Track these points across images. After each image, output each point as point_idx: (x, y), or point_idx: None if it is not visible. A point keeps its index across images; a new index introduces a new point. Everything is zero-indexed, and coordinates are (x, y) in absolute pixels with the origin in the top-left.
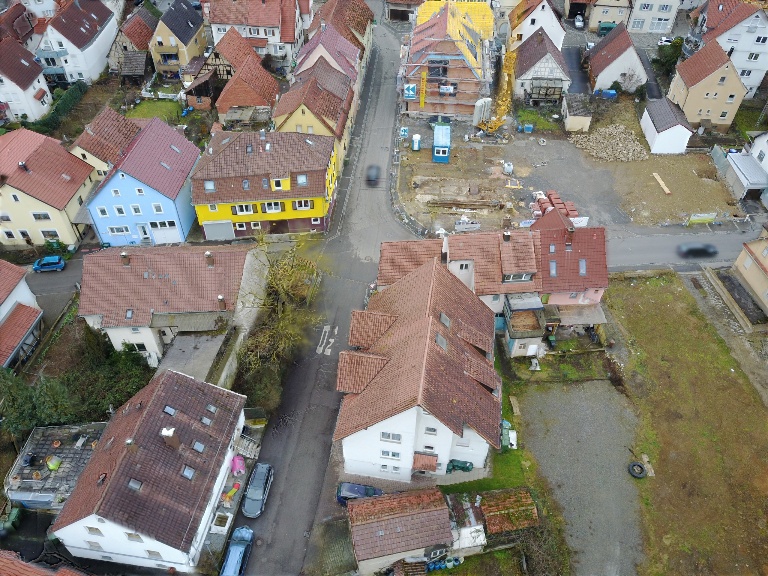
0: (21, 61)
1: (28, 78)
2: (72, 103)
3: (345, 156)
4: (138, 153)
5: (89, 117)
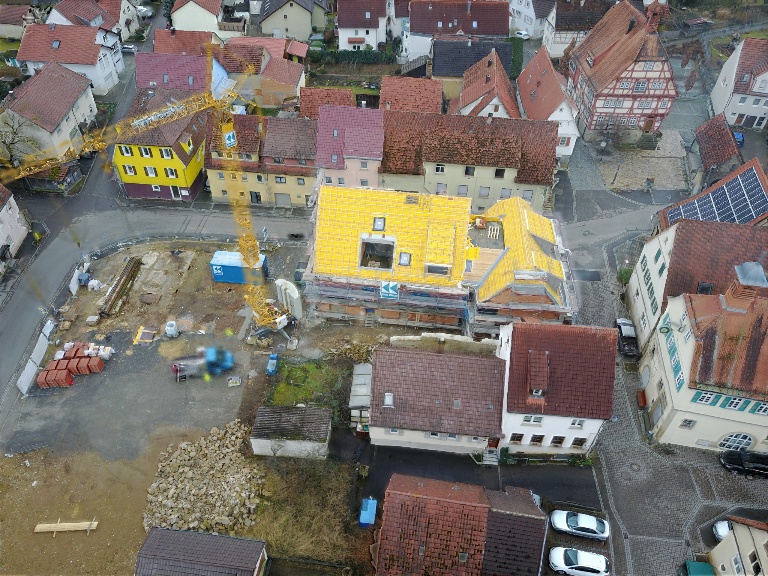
0: (366, 12)
1: (353, 24)
2: (358, 58)
3: (250, 204)
4: (162, 58)
5: (345, 72)
